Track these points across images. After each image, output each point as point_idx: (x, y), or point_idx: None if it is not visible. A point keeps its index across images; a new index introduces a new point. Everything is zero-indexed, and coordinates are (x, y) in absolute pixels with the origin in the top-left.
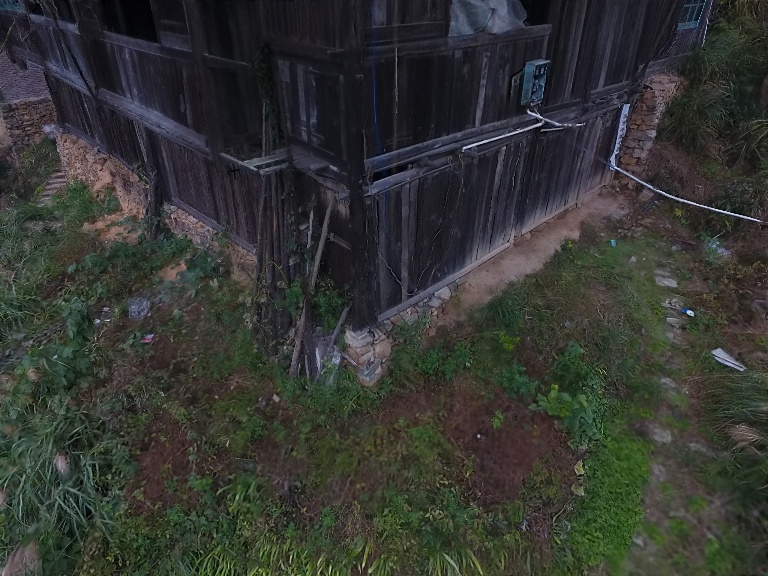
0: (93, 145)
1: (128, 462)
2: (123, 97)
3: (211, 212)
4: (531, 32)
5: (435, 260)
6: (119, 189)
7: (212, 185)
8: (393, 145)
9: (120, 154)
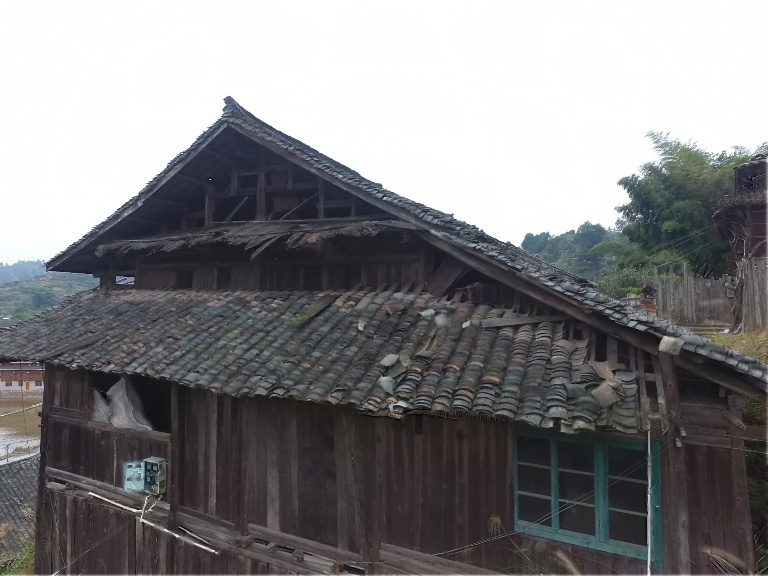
0: None
1: (27, 566)
2: None
3: None
4: (148, 435)
5: (89, 574)
6: None
7: None
8: (61, 467)
9: None
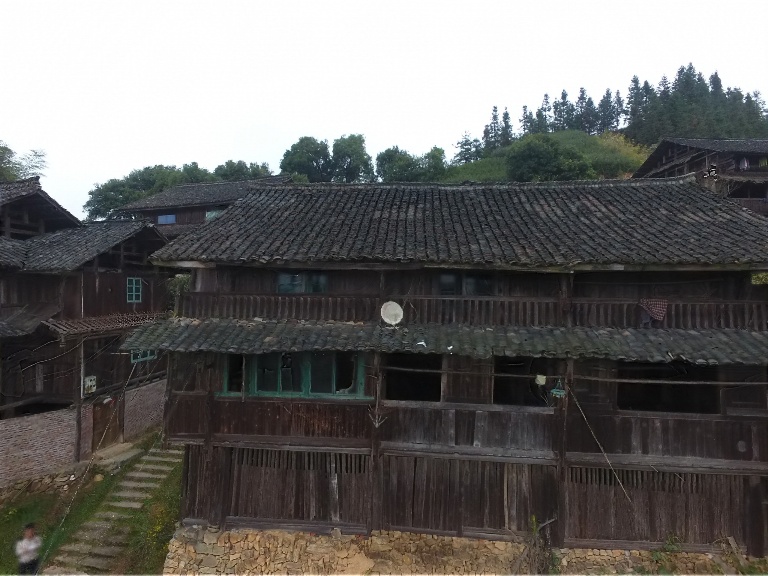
0: (321, 529)
1: None
2: (621, 454)
3: (643, 533)
4: None
5: None
6: (390, 571)
7: (653, 507)
8: None
9: (418, 523)
